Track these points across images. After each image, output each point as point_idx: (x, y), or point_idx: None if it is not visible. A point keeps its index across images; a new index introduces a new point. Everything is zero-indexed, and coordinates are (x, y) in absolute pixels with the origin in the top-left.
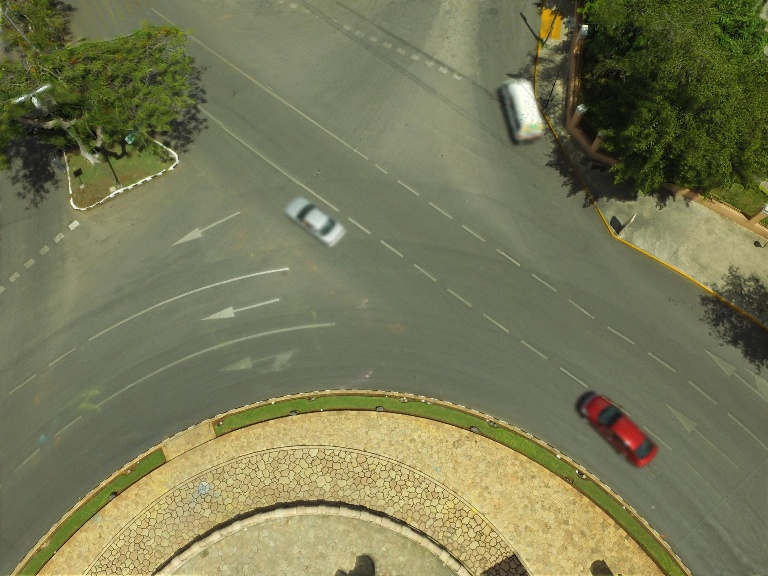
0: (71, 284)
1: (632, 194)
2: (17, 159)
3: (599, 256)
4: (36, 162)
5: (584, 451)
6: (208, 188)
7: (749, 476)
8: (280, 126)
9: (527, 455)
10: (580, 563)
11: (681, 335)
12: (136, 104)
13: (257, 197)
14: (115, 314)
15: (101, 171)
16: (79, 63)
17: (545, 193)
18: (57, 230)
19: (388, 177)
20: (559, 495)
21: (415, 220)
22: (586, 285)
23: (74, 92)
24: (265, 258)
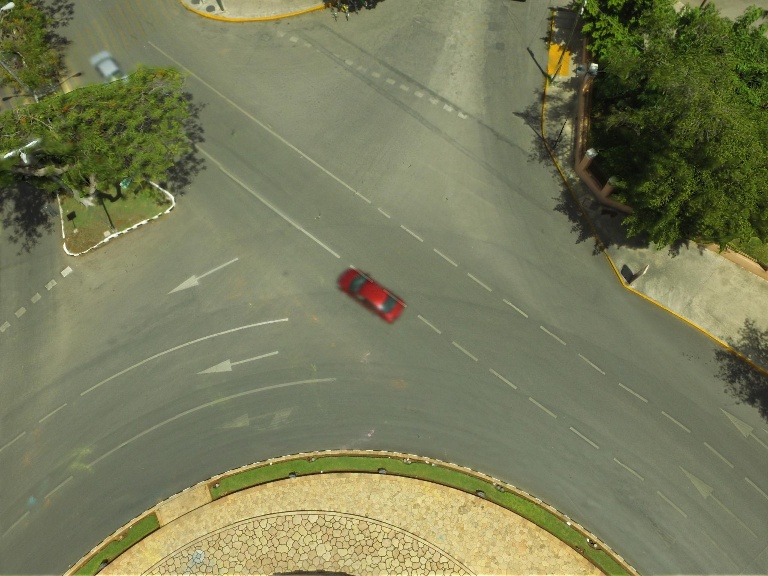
0: (63, 334)
1: (644, 241)
2: (9, 201)
3: (610, 307)
4: (28, 204)
5: (595, 518)
6: (205, 232)
7: (767, 546)
8: (280, 167)
9: (536, 522)
10: None
11: (696, 392)
12: (130, 153)
13: (256, 242)
14: (108, 367)
15: (95, 214)
16: (71, 111)
17: (553, 239)
18: (49, 277)
19: (391, 222)
20: (569, 566)
21: (419, 268)
22: (596, 338)
23: (66, 142)
24: (264, 308)
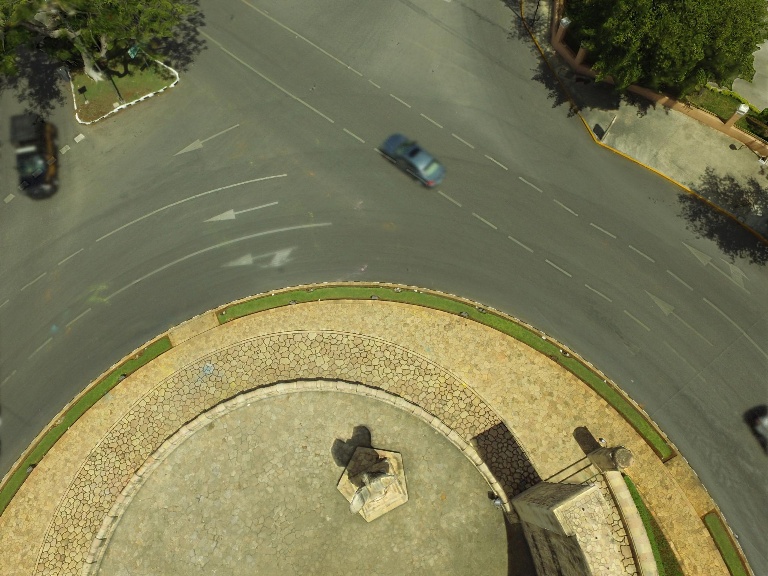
0: (78, 191)
1: (614, 104)
2: (23, 79)
3: (583, 160)
4: (41, 81)
5: (568, 333)
6: (208, 103)
7: (723, 352)
8: (277, 46)
9: (514, 337)
10: (564, 429)
11: (660, 229)
12: (139, 10)
13: (255, 111)
14: (121, 217)
15: (105, 88)
16: None
17: (531, 104)
18: (63, 143)
19: (381, 91)
20: (544, 370)
21: (407, 130)
22: (570, 186)
23: None
24: (264, 165)
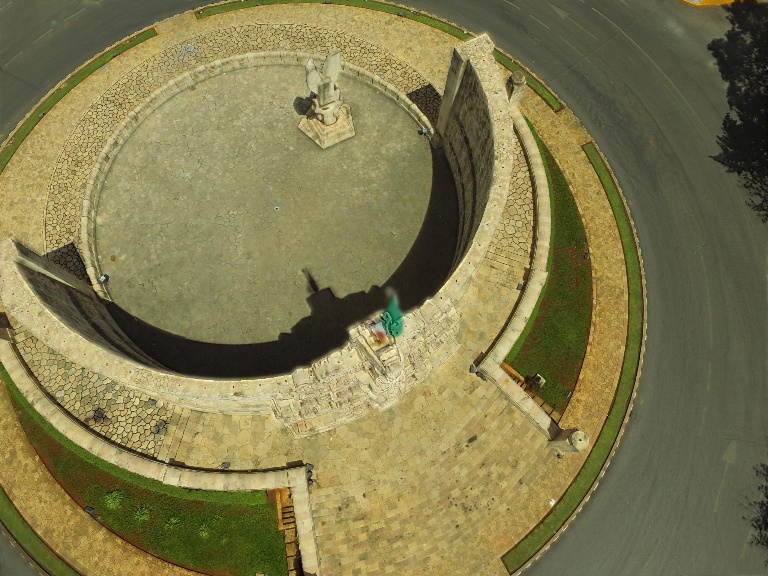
0: None
1: None
2: None
3: None
4: None
5: (485, 30)
6: None
7: (604, 44)
8: None
9: (441, 30)
10: None
11: None
12: None
13: None
14: None
15: None
16: None
17: None
18: None
19: None
20: None
21: None
22: None
23: None
24: None
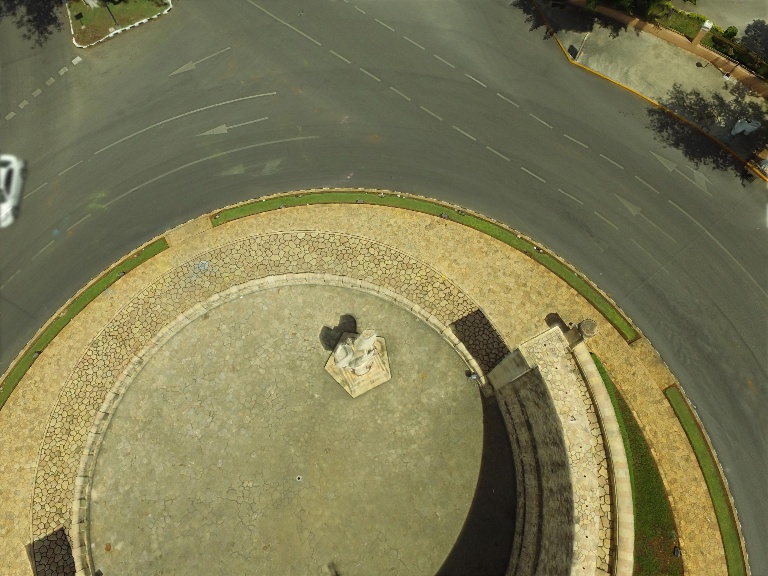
0: (76, 109)
1: (588, 26)
2: (21, 7)
3: (557, 78)
4: (39, 9)
5: (541, 232)
6: (200, 28)
7: (685, 248)
8: None
9: (491, 235)
10: (536, 315)
11: (629, 140)
12: None
13: (246, 35)
14: (118, 132)
15: (100, 14)
16: None
17: (509, 28)
18: (61, 65)
19: (366, 16)
20: (519, 264)
21: (391, 51)
22: (545, 101)
23: None
24: (254, 84)
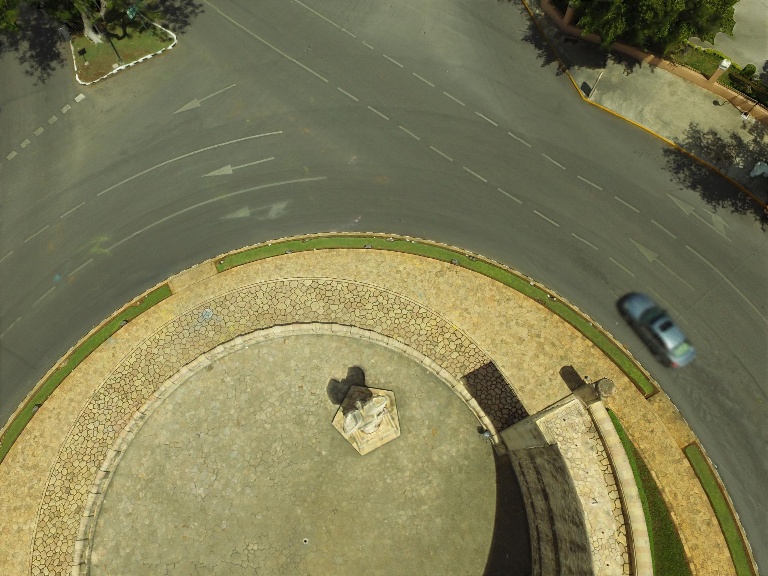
0: (79, 148)
1: (601, 63)
2: (24, 42)
3: (570, 116)
4: (42, 44)
5: (555, 279)
6: (205, 64)
7: (704, 296)
8: (272, 9)
9: (503, 282)
10: (550, 368)
11: (645, 181)
12: None
13: (252, 71)
14: (121, 173)
15: (104, 50)
16: None
17: (521, 64)
18: (64, 102)
19: (374, 52)
20: (532, 314)
21: (400, 88)
22: (558, 141)
23: None
24: (260, 123)
